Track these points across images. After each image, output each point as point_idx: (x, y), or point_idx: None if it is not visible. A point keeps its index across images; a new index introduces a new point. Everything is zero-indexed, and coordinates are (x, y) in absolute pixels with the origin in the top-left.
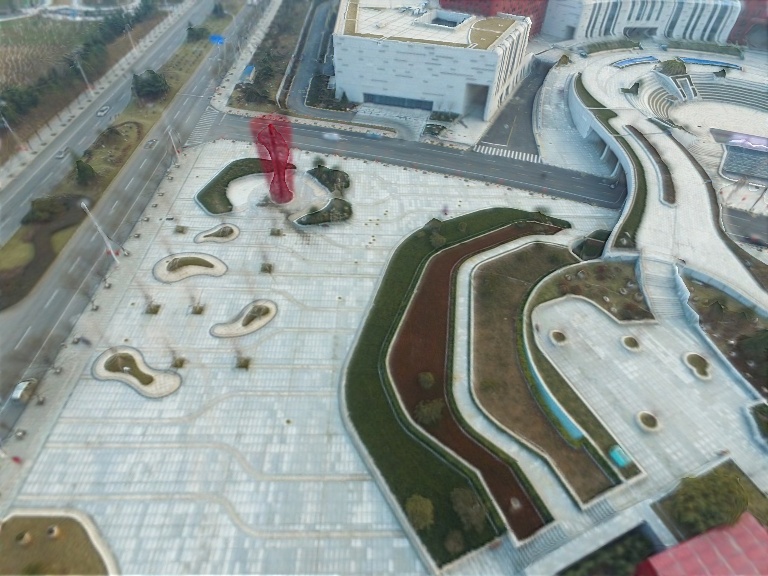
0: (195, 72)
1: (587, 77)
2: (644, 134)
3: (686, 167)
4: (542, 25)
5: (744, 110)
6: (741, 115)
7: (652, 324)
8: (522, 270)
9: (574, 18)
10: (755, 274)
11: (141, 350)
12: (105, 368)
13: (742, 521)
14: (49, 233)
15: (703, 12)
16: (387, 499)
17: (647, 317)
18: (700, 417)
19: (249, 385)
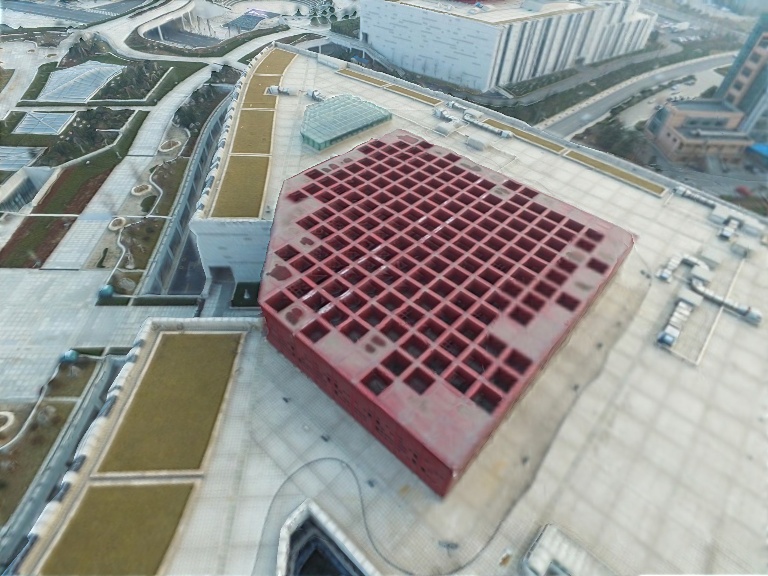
0: None
1: None
2: (176, 0)
3: None
4: None
5: (294, 4)
6: (287, 6)
7: (54, 49)
8: (22, 37)
9: None
10: (129, 37)
11: None
12: None
13: None
14: None
15: None
16: None
17: (52, 46)
18: None
19: None
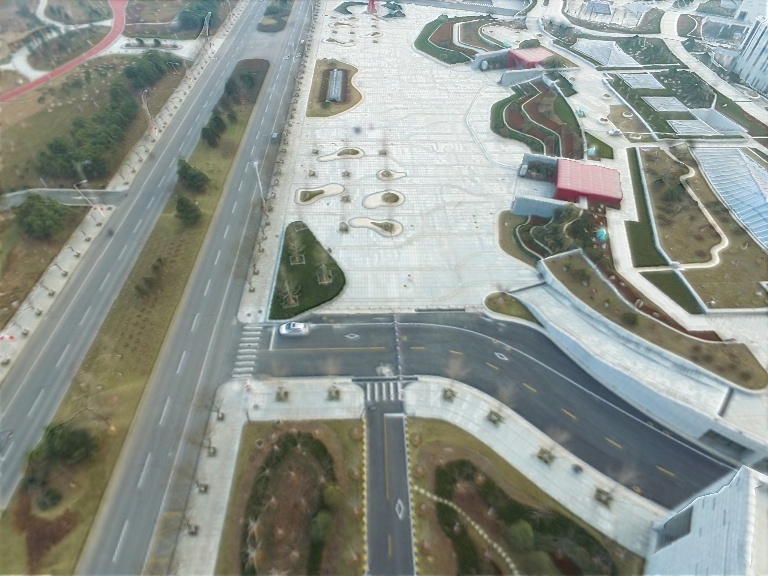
0: None
1: None
2: None
3: None
4: None
5: None
6: None
7: (527, 31)
8: None
9: None
10: None
11: (337, 39)
12: (327, 41)
13: None
14: (279, 17)
15: None
16: (433, 60)
17: (525, 29)
18: None
19: None
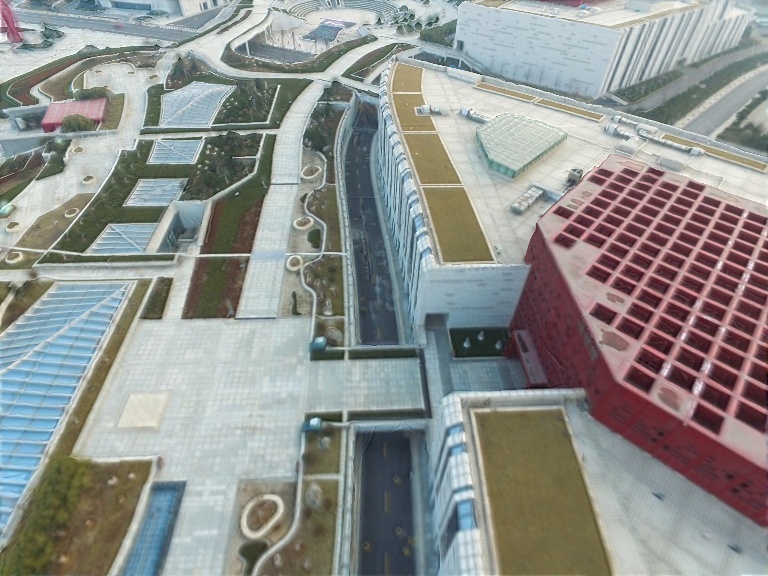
0: None
1: None
2: None
3: None
4: None
5: (365, 12)
6: (358, 14)
7: (152, 70)
8: (114, 58)
9: None
10: None
11: None
12: None
13: (100, 99)
14: None
15: None
16: None
17: (150, 67)
18: (132, 88)
19: None
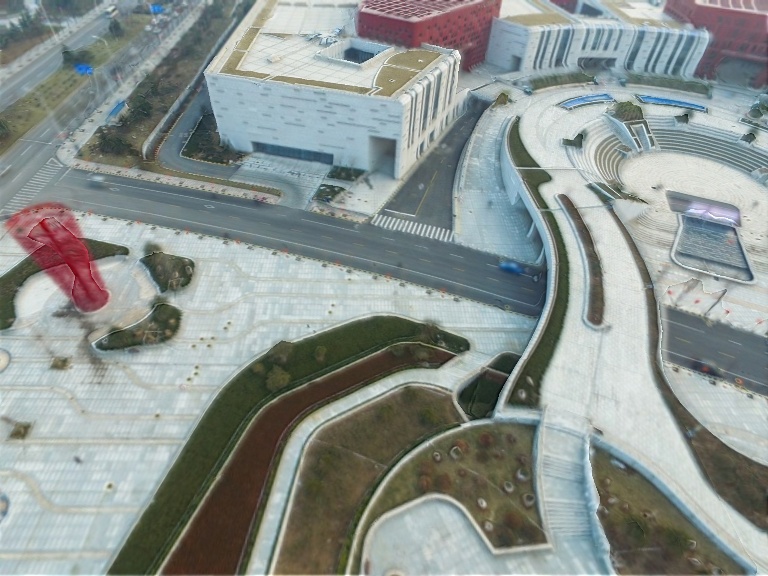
0: (56, 109)
1: (526, 122)
2: (579, 208)
3: (624, 262)
4: (486, 53)
5: (708, 164)
6: (704, 171)
7: (542, 552)
8: (378, 439)
9: (519, 47)
10: (698, 453)
11: None
12: None
13: None
14: None
15: (667, 42)
16: None
17: (535, 541)
18: None
19: None
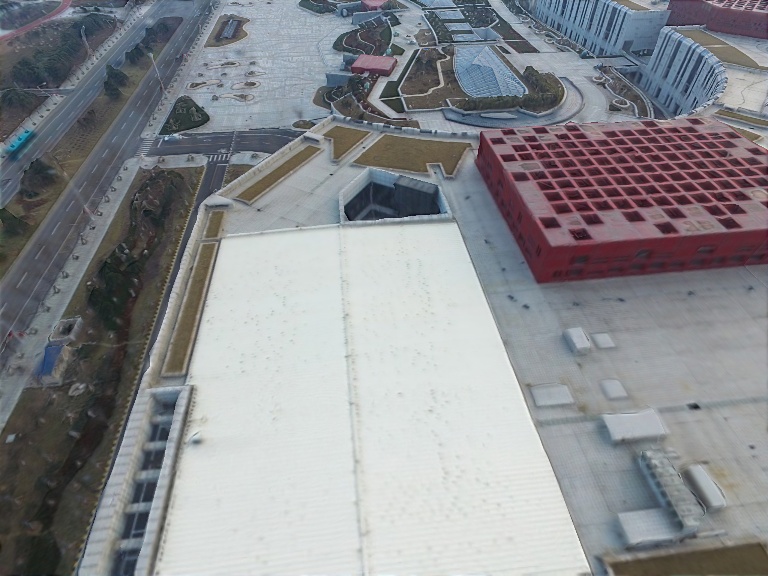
0: None
1: None
2: None
3: None
4: None
5: None
6: None
7: None
8: None
9: None
10: None
11: None
12: (231, 4)
13: None
14: None
15: None
16: None
17: None
18: None
19: (272, 5)
